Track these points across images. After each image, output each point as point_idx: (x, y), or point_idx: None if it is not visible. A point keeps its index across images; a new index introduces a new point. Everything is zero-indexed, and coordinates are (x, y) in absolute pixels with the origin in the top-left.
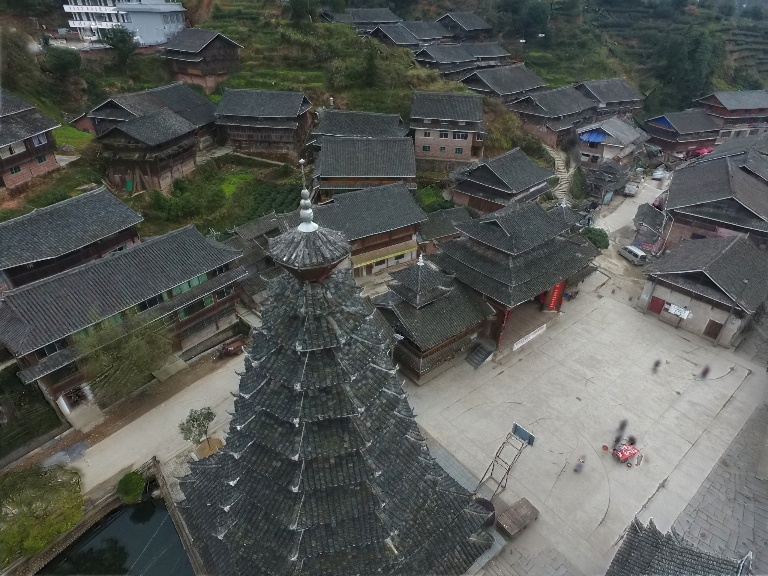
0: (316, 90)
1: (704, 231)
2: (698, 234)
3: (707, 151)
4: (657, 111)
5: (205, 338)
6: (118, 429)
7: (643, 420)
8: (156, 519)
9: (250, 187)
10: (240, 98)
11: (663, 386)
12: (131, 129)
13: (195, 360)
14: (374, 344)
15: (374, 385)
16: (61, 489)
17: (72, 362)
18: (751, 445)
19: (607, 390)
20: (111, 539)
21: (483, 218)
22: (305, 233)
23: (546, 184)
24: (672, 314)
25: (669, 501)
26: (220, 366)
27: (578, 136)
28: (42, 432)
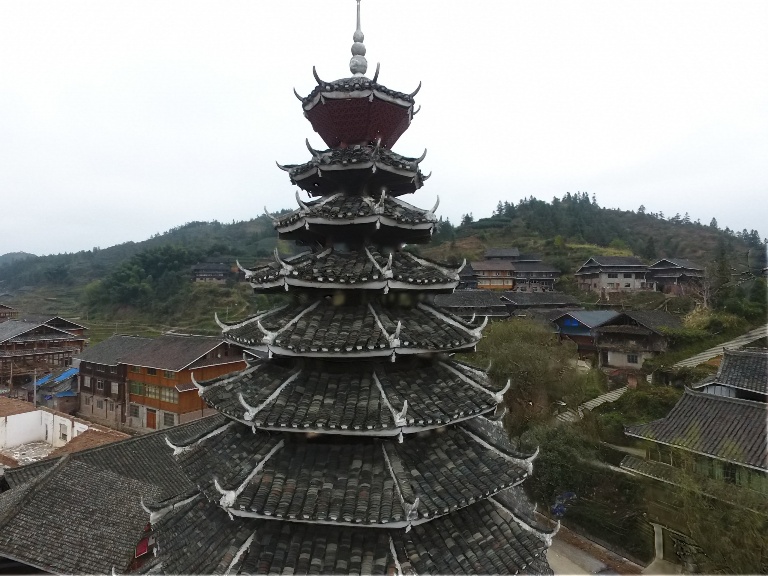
0: None
1: None
2: None
3: None
4: None
5: None
6: None
7: None
8: None
9: None
10: None
11: None
12: None
13: None
14: None
15: None
16: None
17: (670, 484)
18: None
19: None
20: None
21: None
22: None
23: None
24: None
25: None
26: None
27: None
28: (632, 550)
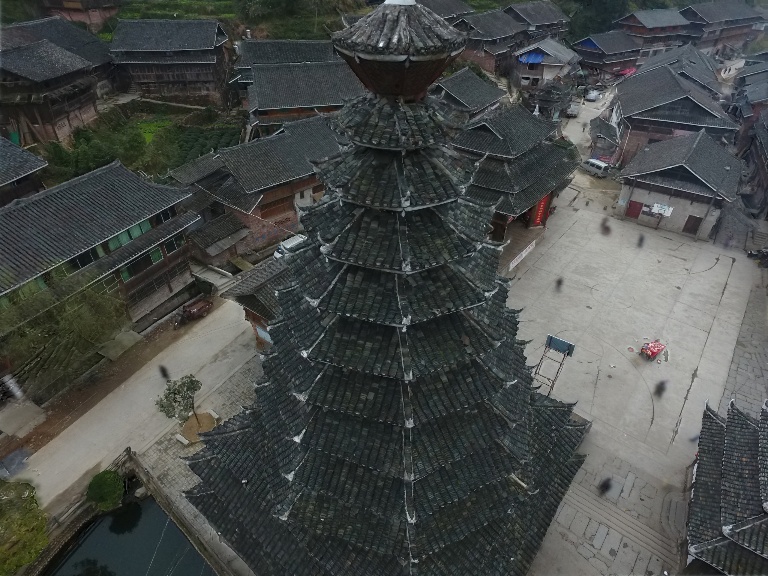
0: (228, 22)
1: (661, 135)
2: (655, 139)
3: (633, 69)
4: (582, 33)
5: (158, 303)
6: (68, 424)
7: (656, 318)
8: (146, 522)
9: (171, 135)
10: (139, 30)
11: (663, 284)
12: (4, 62)
13: (151, 330)
14: (482, 207)
15: (486, 266)
16: (10, 508)
17: None
18: (759, 325)
19: (613, 295)
20: (87, 559)
21: (469, 124)
22: (402, 6)
23: (499, 105)
24: (651, 216)
25: (707, 389)
26: (185, 332)
27: (515, 60)
28: None
